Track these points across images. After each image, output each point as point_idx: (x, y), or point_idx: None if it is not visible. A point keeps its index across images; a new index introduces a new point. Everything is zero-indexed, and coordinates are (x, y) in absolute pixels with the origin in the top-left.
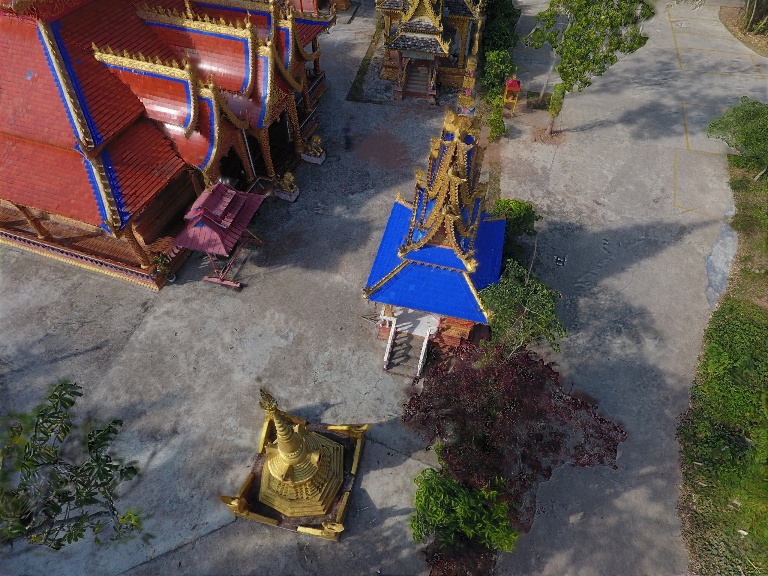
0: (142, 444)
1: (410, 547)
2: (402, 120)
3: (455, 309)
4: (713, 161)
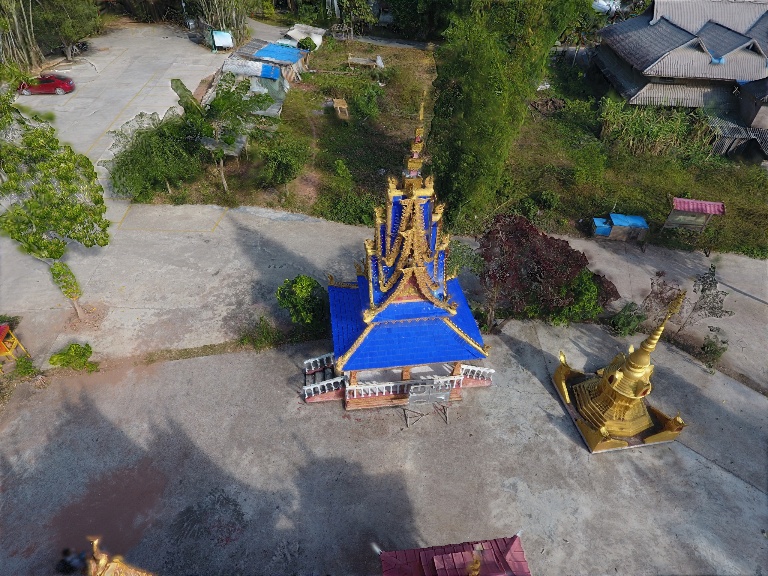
0: (716, 567)
1: (591, 336)
2: (4, 513)
3: (459, 295)
4: (141, 211)
